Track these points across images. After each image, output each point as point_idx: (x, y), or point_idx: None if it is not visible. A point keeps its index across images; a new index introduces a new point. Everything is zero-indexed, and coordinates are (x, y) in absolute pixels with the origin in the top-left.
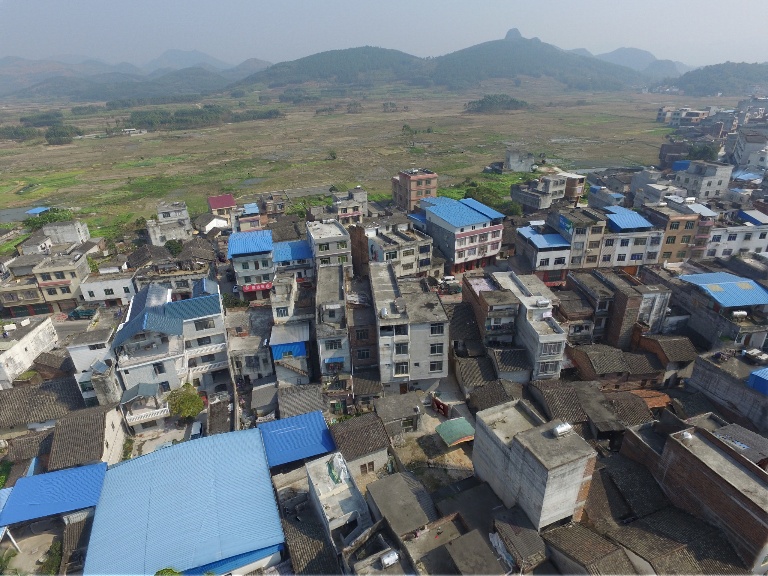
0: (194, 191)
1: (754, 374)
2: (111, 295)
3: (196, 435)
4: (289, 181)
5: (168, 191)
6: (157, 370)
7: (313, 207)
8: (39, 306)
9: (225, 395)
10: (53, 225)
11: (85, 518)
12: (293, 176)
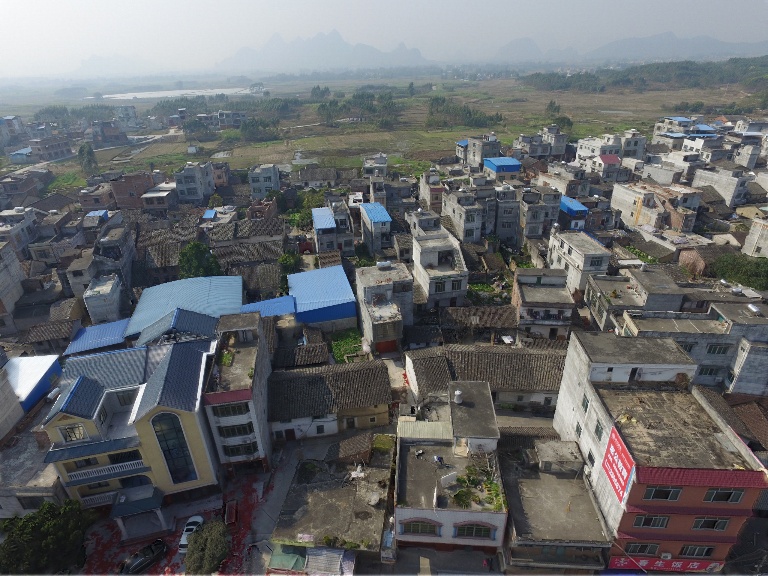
0: None
1: None
2: None
3: None
4: None
5: None
6: None
7: None
8: None
9: None
10: None
11: None
12: None
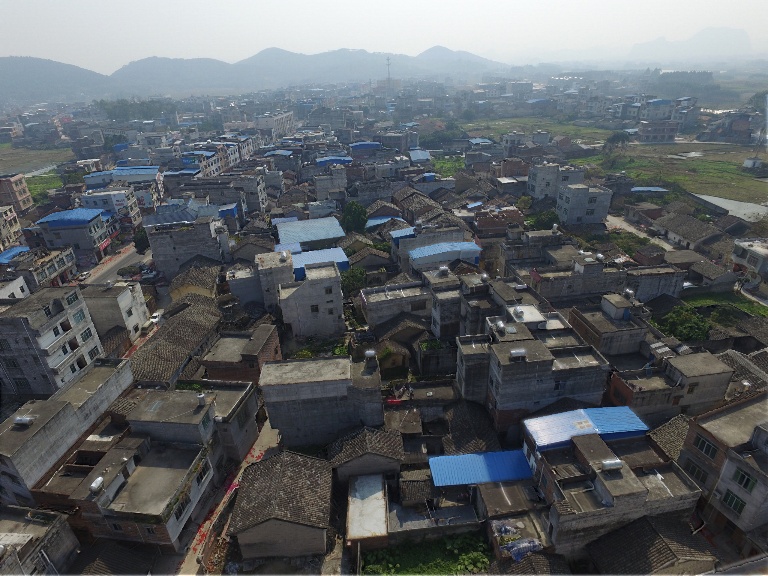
0: None
1: (318, 162)
2: None
3: None
4: None
5: None
6: None
7: None
8: None
9: None
10: None
11: None
12: None
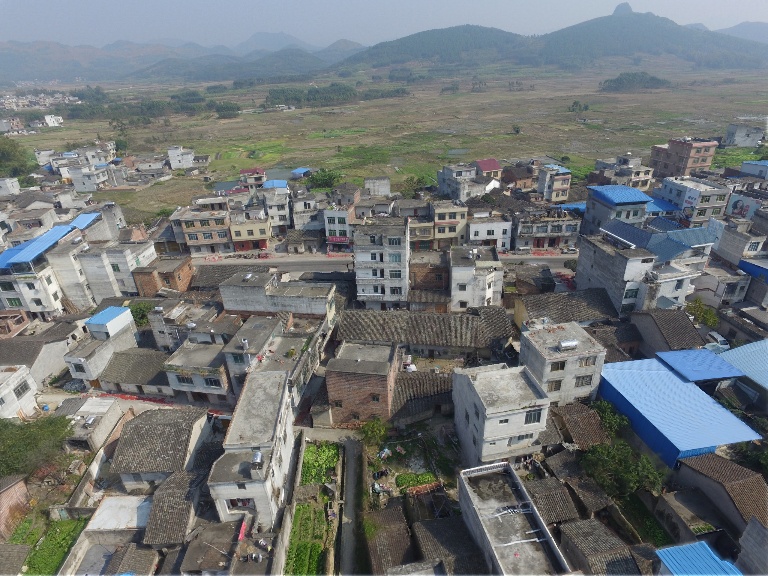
0: (412, 159)
1: None
2: (491, 236)
3: (723, 341)
4: (496, 152)
5: (387, 158)
6: (677, 286)
7: (606, 170)
8: (424, 243)
9: (730, 312)
10: (373, 179)
11: (729, 386)
12: (494, 148)
